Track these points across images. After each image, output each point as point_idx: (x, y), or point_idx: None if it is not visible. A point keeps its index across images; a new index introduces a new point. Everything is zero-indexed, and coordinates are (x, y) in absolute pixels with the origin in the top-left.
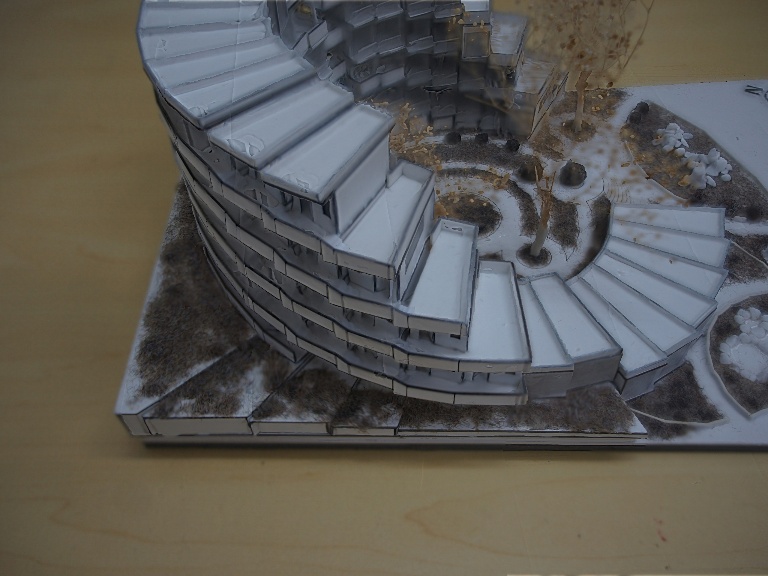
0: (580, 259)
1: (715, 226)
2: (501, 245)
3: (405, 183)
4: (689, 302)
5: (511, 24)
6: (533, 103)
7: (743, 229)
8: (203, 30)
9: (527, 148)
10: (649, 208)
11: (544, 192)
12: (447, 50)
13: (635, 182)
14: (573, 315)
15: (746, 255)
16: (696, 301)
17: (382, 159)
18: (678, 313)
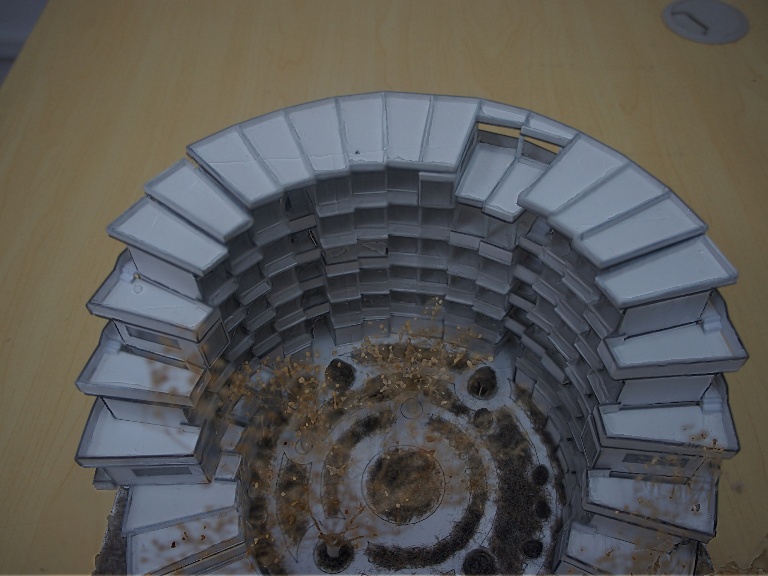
0: None
1: None
2: None
3: None
4: None
5: (708, 516)
6: None
7: None
8: None
9: (537, 571)
10: None
11: None
12: None
13: None
14: (186, 548)
15: None
16: None
17: (193, 284)
18: None
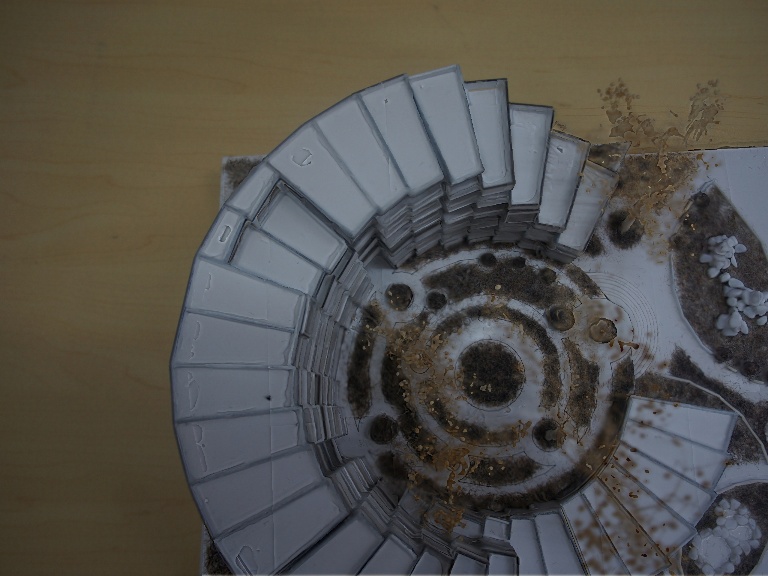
0: (590, 443)
1: (723, 433)
2: (520, 419)
3: (427, 557)
4: (673, 525)
5: (568, 142)
6: (576, 254)
7: (757, 393)
8: (236, 417)
9: (564, 275)
10: (666, 404)
11: (571, 347)
12: (489, 215)
13: (668, 318)
14: (567, 558)
15: (749, 431)
16: (680, 525)
17: None
18: (661, 536)
